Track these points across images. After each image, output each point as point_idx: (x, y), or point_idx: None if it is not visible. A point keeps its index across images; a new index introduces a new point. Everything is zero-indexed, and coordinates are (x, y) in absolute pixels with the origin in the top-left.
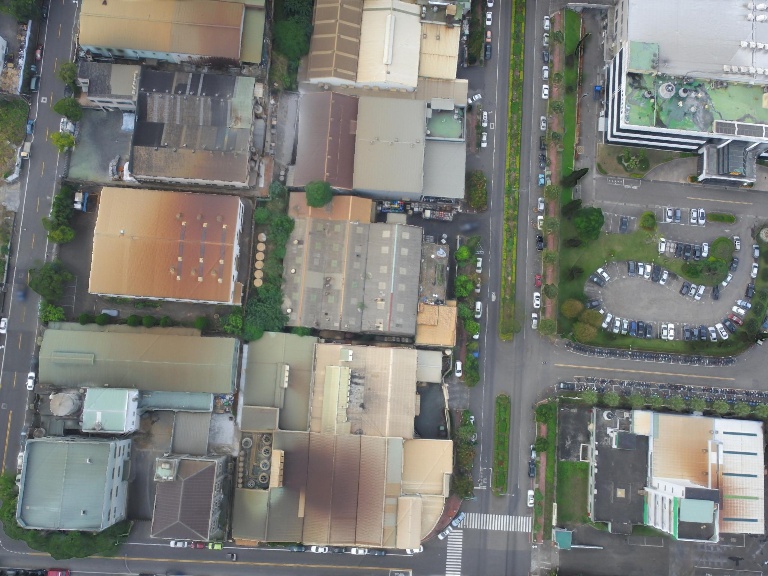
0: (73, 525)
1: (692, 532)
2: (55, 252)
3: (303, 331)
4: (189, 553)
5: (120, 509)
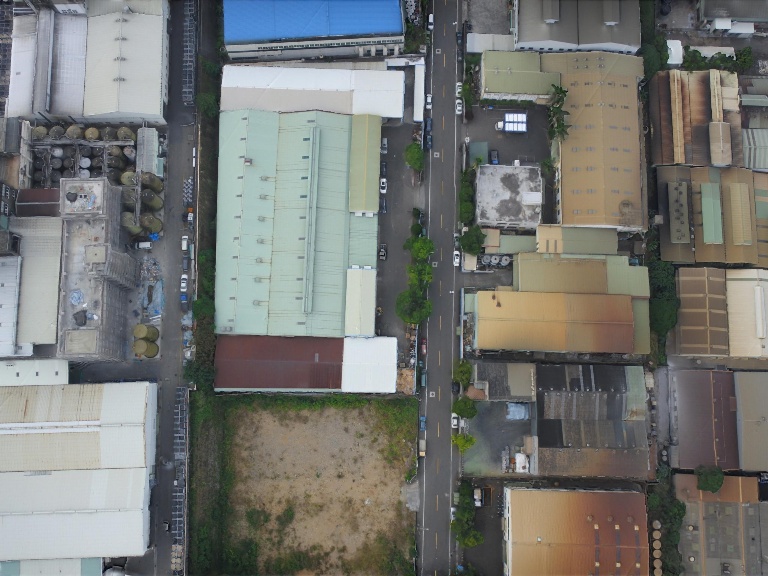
0: None
1: None
2: (461, 553)
3: None
4: None
5: None
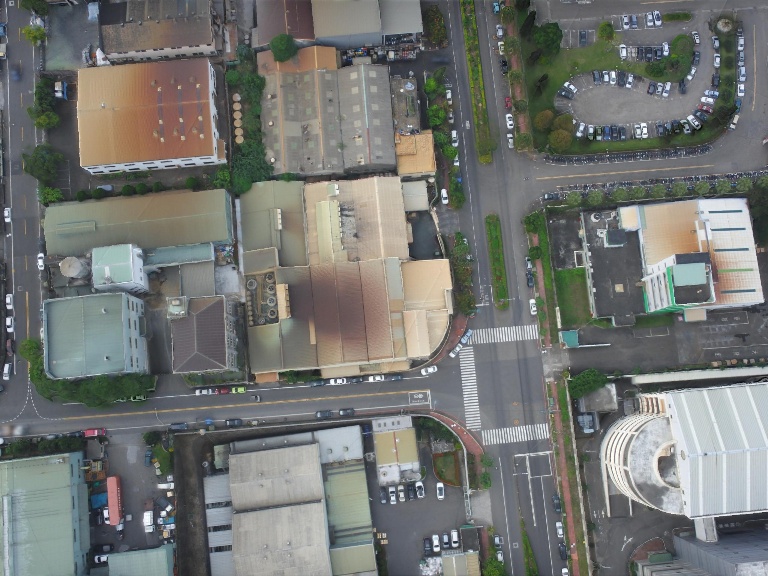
0: (99, 371)
1: (689, 298)
2: (44, 140)
3: (289, 176)
4: (215, 400)
5: (142, 362)
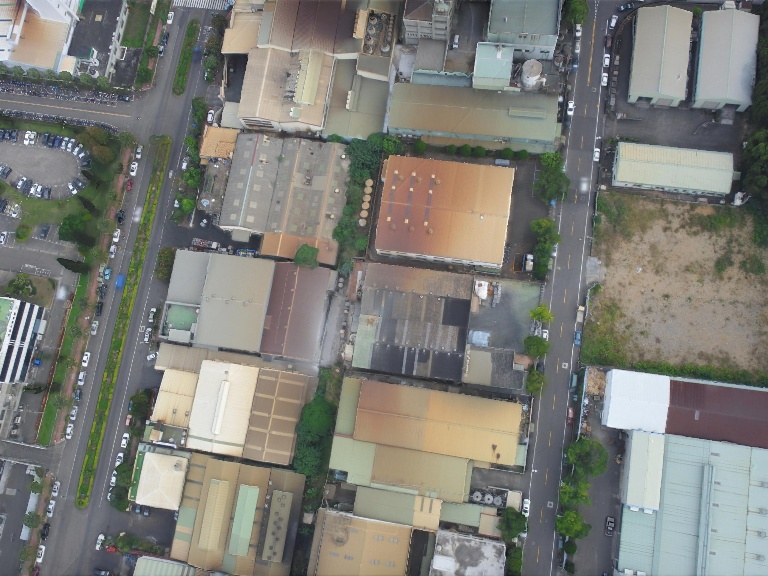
0: None
1: None
2: None
3: (332, 138)
4: None
5: None
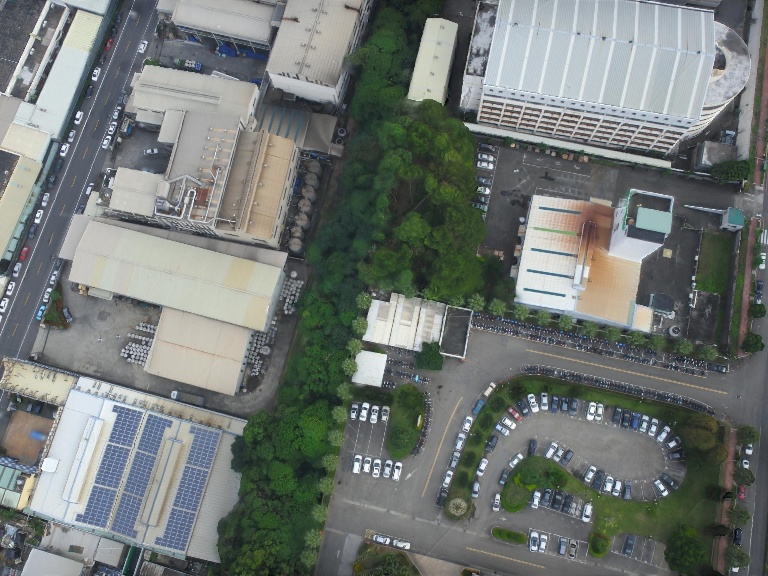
0: None
1: (652, 202)
2: None
3: None
4: None
5: None
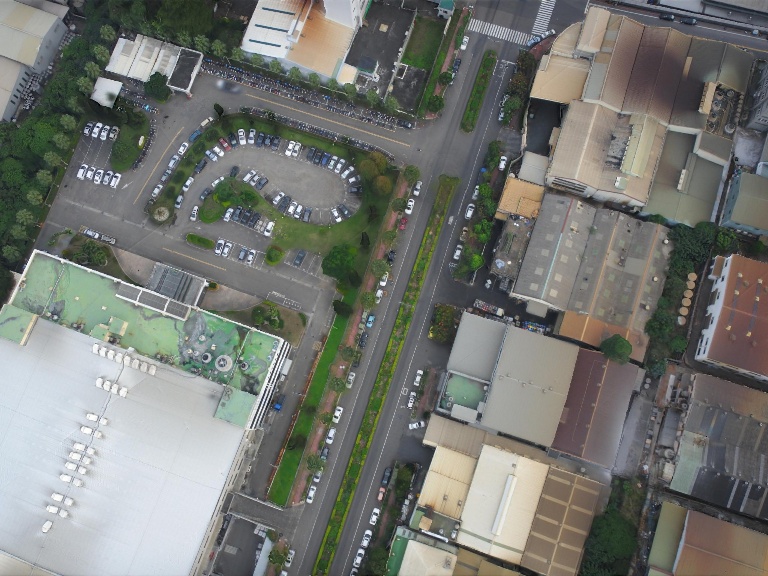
0: None
1: None
2: None
3: (657, 218)
4: None
5: None
